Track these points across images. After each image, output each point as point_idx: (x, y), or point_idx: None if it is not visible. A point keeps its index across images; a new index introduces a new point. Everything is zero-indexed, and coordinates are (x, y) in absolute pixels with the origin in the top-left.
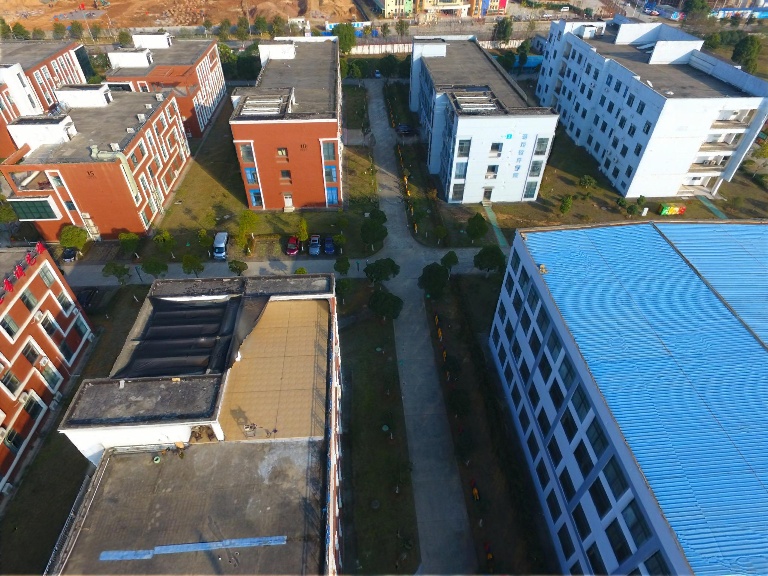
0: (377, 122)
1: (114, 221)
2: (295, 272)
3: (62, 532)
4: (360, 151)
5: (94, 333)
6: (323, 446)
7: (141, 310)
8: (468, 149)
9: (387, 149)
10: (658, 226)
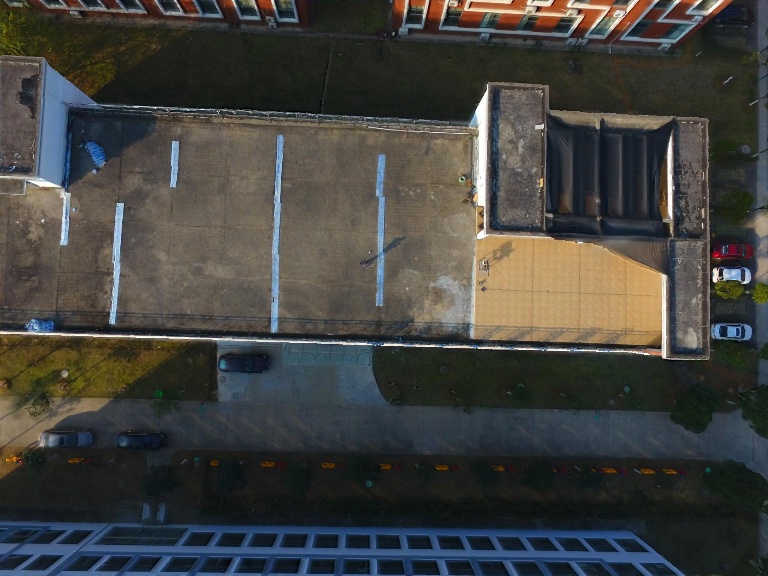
0: None
1: None
2: (766, 285)
3: (400, 119)
4: None
5: (672, 47)
6: (463, 338)
7: (651, 117)
8: None
9: None
10: None
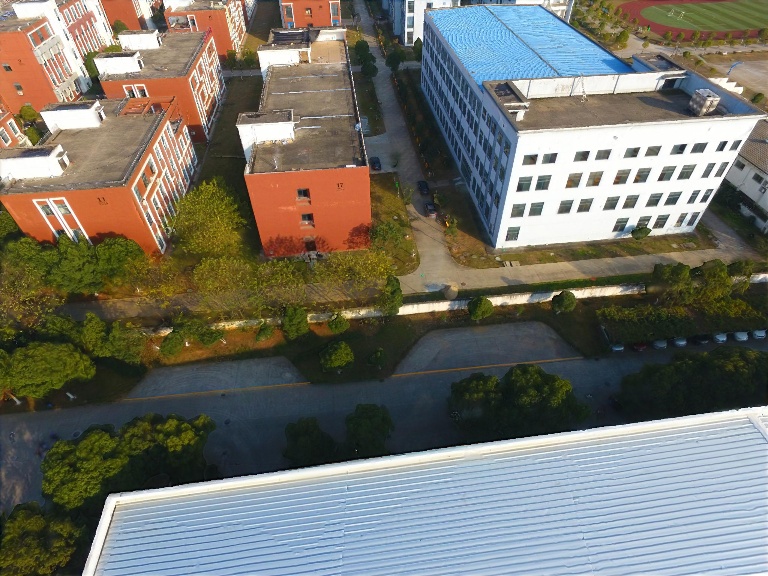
0: (361, 15)
1: (219, 50)
2: None
3: None
4: (351, 28)
5: None
6: None
7: None
8: (413, 7)
9: (368, 27)
10: (486, 6)
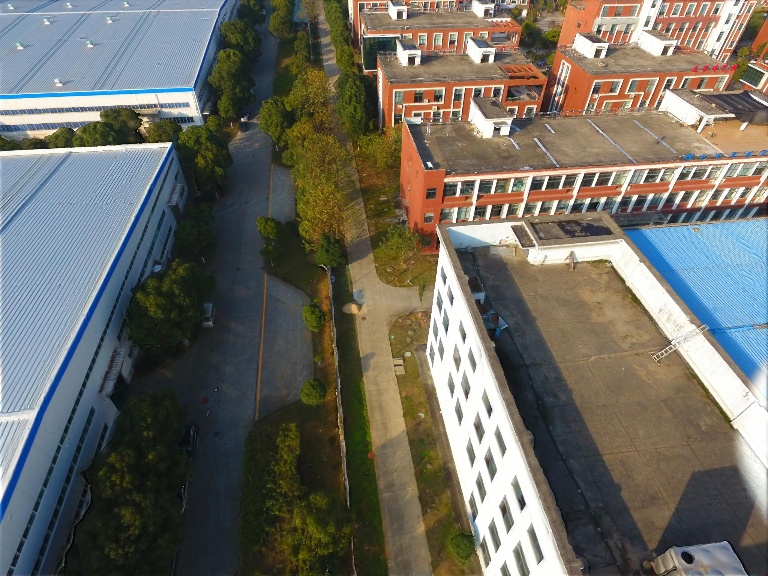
0: None
1: None
2: None
3: None
4: None
5: None
6: None
7: None
8: None
9: None
10: None
